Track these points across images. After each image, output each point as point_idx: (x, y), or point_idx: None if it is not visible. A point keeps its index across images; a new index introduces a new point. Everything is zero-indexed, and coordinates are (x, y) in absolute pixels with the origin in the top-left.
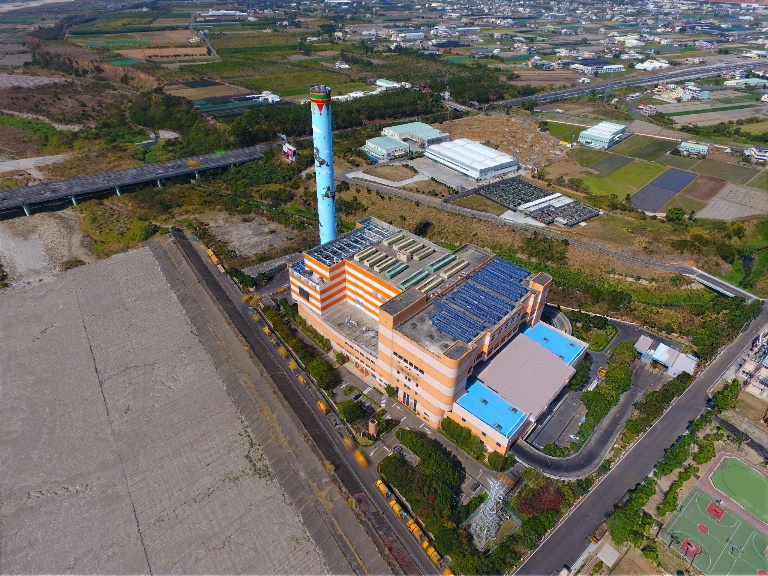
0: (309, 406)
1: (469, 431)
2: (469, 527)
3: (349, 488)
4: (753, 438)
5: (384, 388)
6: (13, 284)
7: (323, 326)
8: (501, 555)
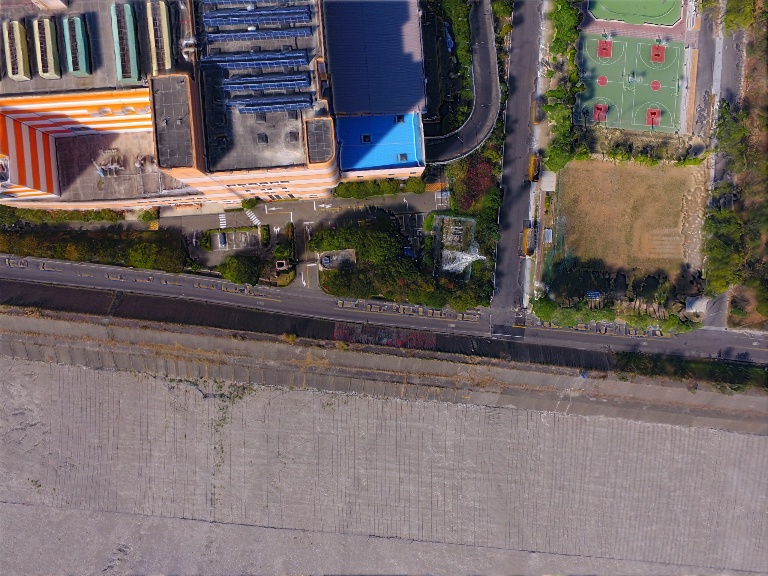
0: (191, 298)
1: (374, 183)
2: (438, 264)
3: (324, 336)
4: None
5: (237, 203)
6: None
7: (81, 206)
8: (481, 266)
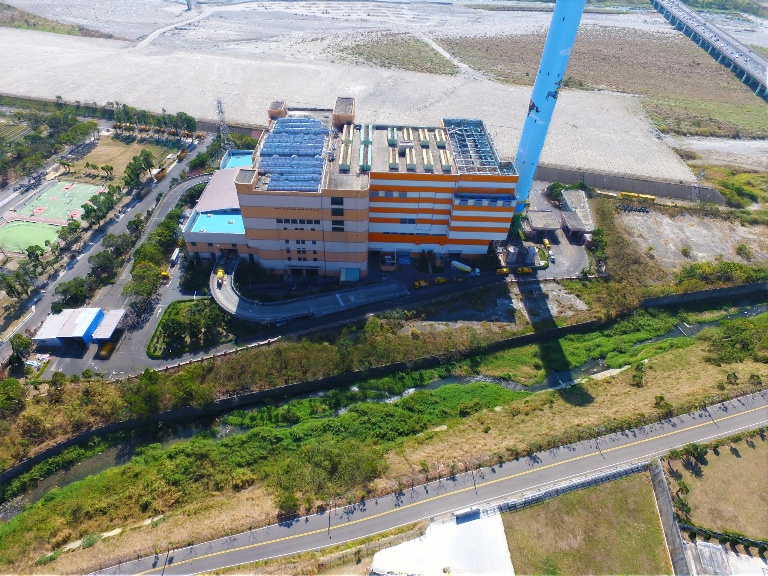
0: None
1: None
2: None
3: None
4: None
5: None
6: (666, 135)
7: None
8: None
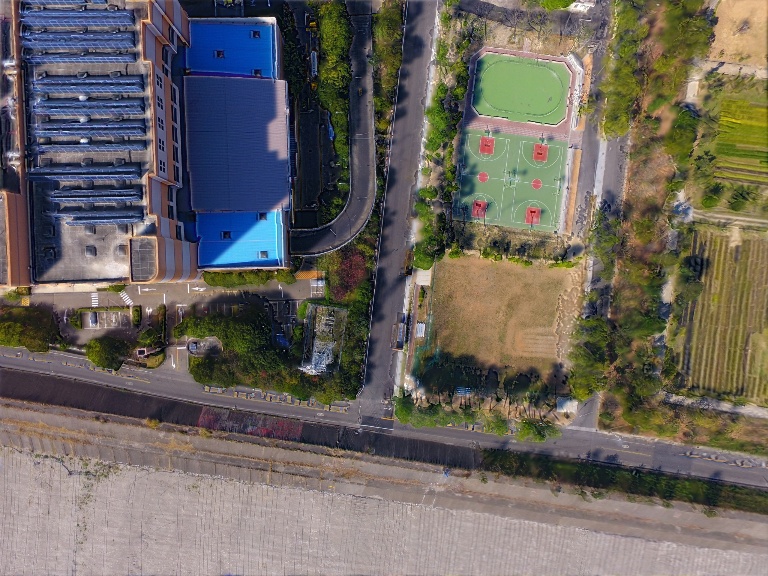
0: (60, 375)
1: (239, 275)
2: (309, 353)
3: (189, 422)
4: (495, 3)
5: None
6: None
7: None
8: (349, 359)
